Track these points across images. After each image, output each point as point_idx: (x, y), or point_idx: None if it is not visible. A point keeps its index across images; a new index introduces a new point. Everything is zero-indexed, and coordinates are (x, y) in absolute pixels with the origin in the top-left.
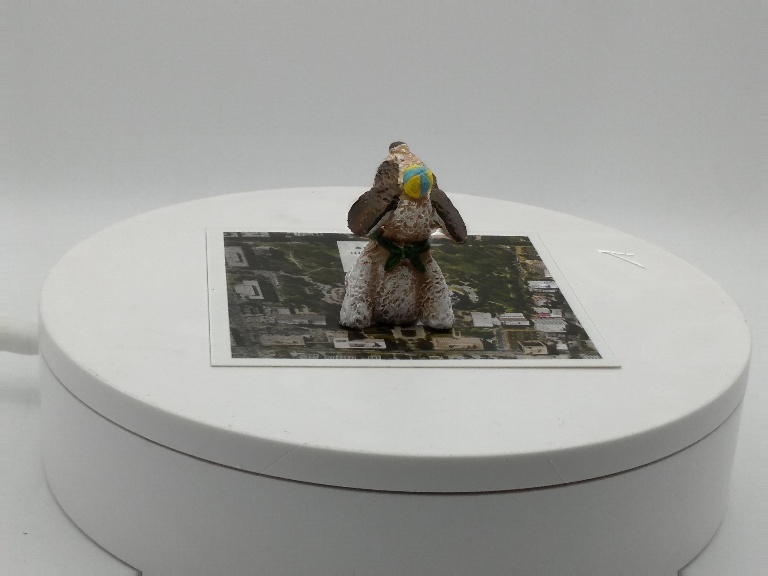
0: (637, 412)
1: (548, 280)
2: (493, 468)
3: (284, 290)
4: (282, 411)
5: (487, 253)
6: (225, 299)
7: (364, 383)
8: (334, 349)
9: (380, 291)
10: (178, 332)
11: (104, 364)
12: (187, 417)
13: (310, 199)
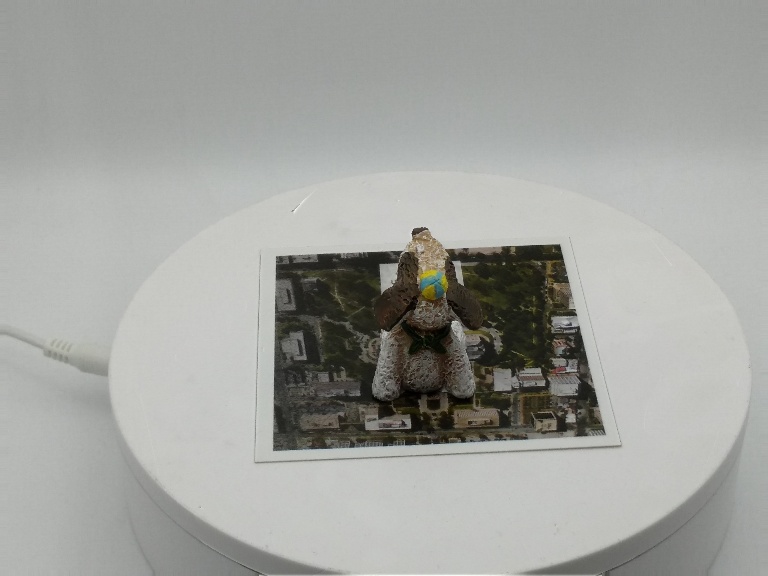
0: (627, 510)
1: (571, 314)
2: None
3: (326, 345)
4: (313, 524)
5: (518, 275)
6: (272, 362)
7: (387, 480)
8: (364, 432)
9: (406, 368)
10: (228, 413)
11: (163, 464)
12: (231, 535)
13: (360, 195)
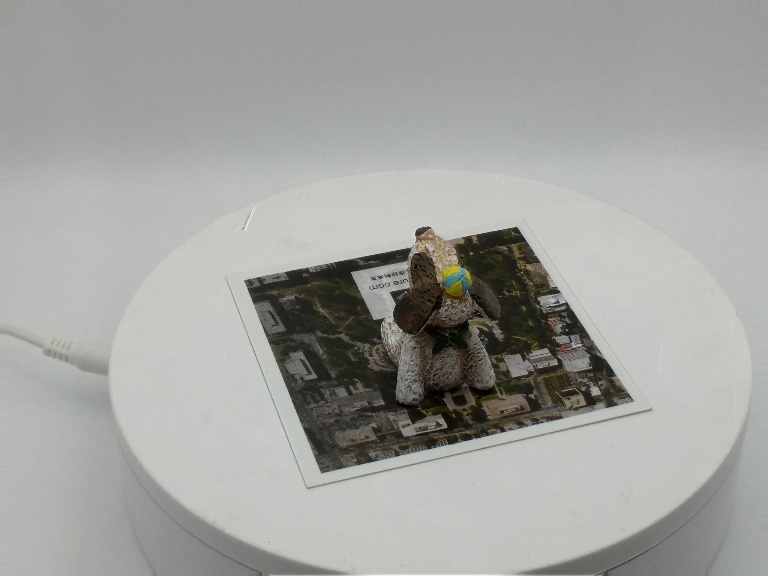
0: (682, 469)
1: (555, 292)
2: (582, 565)
3: (331, 360)
4: (390, 538)
5: (490, 262)
6: (284, 386)
7: (445, 482)
8: (404, 439)
9: (429, 369)
10: (260, 444)
11: (213, 506)
12: (312, 565)
13: (303, 208)
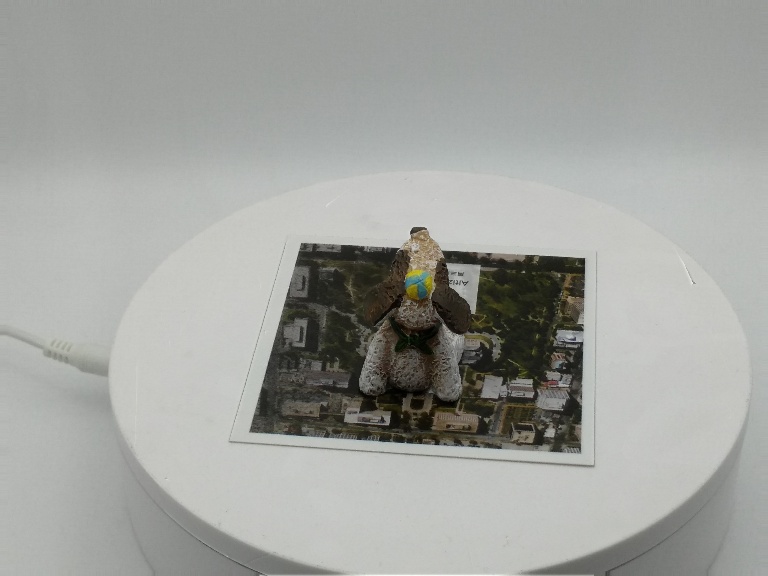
0: (583, 531)
1: (577, 329)
2: None
3: (327, 335)
4: (269, 507)
5: (535, 285)
6: (270, 346)
7: (352, 473)
8: (342, 424)
9: (393, 365)
10: (216, 391)
11: (141, 433)
12: (188, 509)
13: (399, 191)
